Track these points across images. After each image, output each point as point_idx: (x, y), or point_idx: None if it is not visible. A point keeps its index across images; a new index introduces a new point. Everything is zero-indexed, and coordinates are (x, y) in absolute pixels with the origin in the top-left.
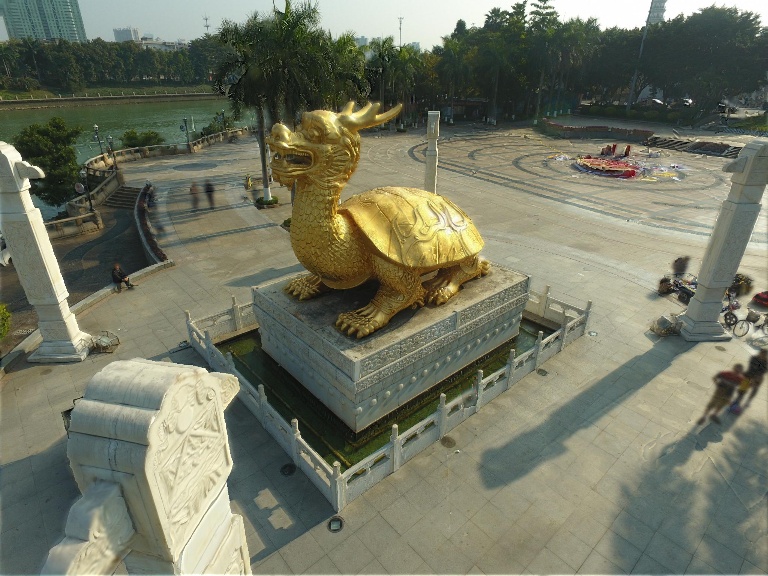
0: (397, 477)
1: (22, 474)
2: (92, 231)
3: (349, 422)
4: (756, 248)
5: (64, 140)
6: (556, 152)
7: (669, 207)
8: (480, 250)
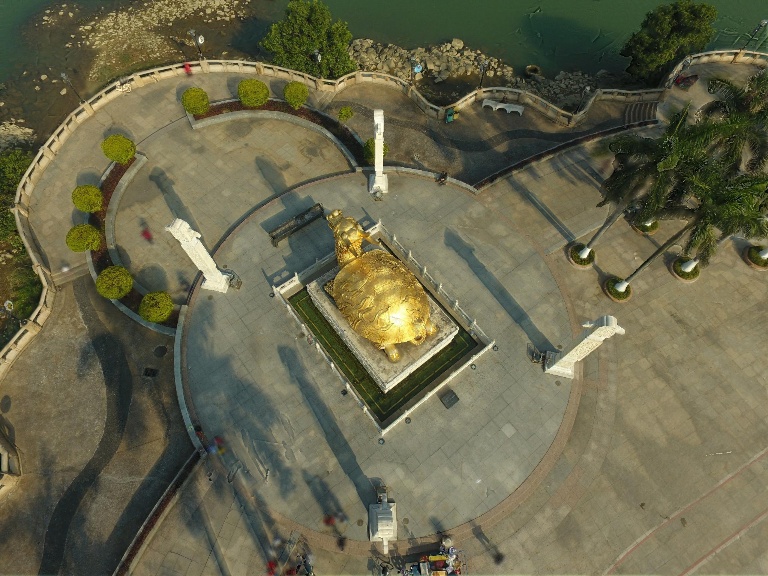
0: (287, 314)
1: (307, 204)
2: (562, 124)
3: None
4: None
5: (684, 32)
6: None
7: None
8: None
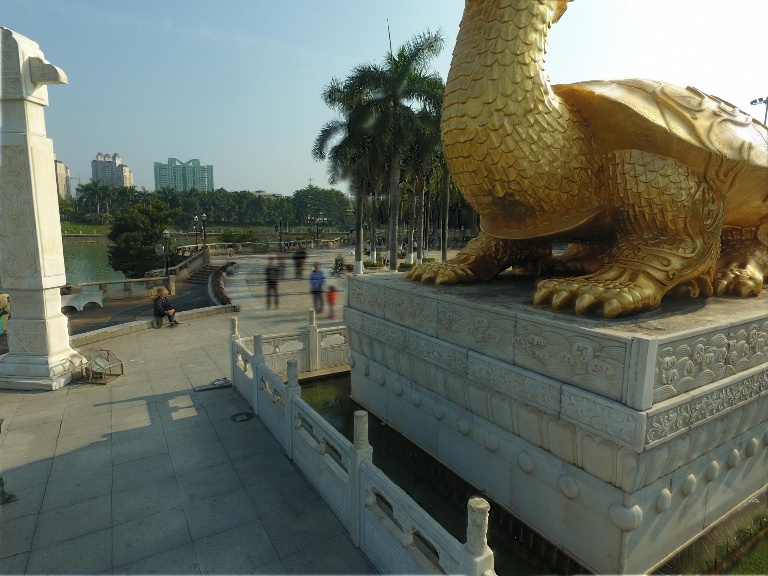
0: None
1: None
2: None
3: (589, 555)
4: None
5: (162, 220)
6: None
7: None
8: None
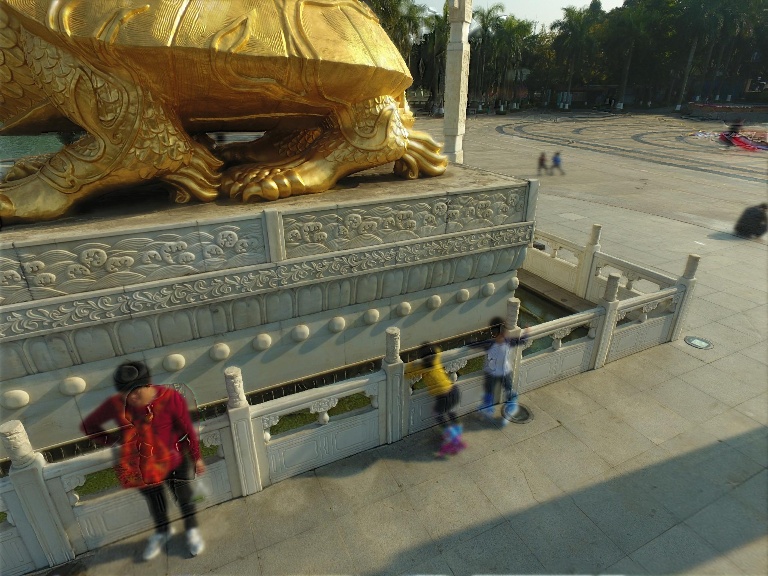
0: None
1: None
2: None
3: None
4: None
5: None
6: (700, 130)
7: None
8: (360, 64)
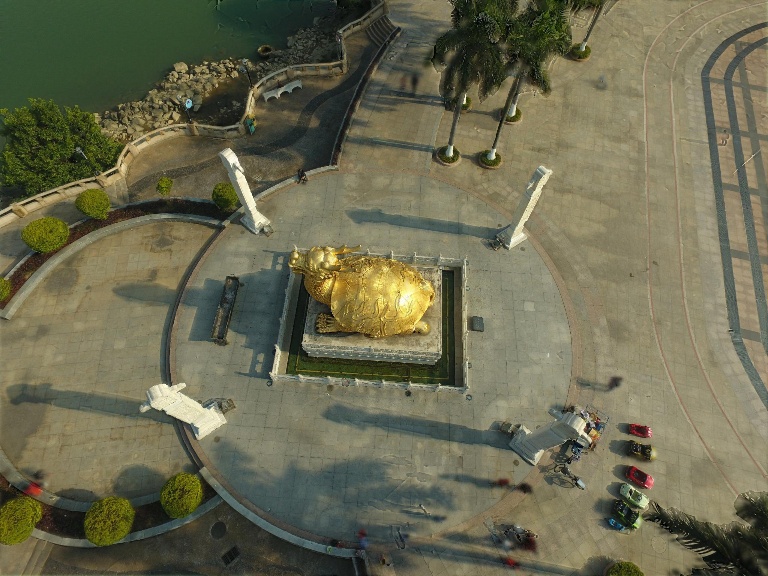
0: (300, 385)
1: (213, 287)
2: (337, 75)
3: None
4: None
5: None
6: None
7: None
8: None
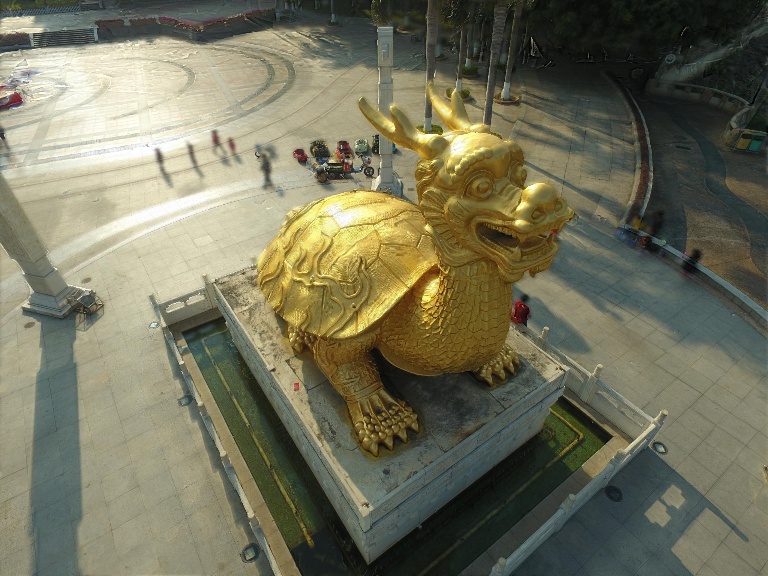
0: None
1: None
2: None
3: None
4: (256, 120)
5: None
6: None
7: (136, 117)
8: None
